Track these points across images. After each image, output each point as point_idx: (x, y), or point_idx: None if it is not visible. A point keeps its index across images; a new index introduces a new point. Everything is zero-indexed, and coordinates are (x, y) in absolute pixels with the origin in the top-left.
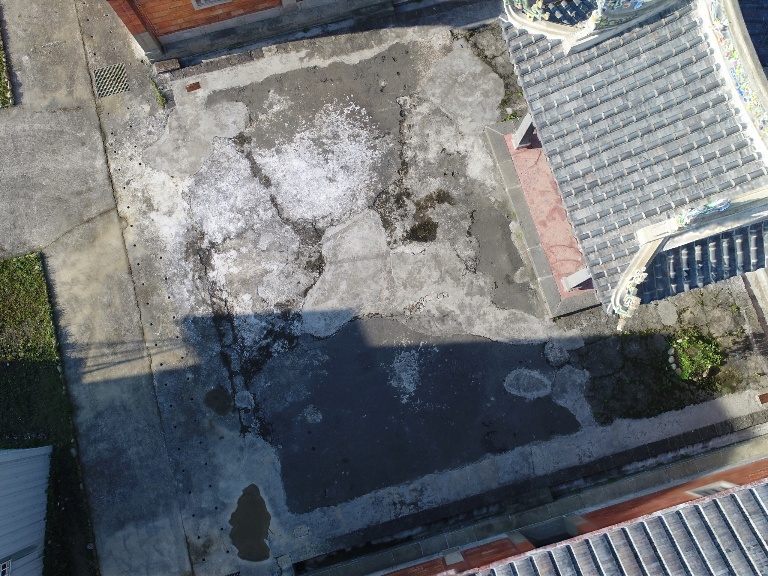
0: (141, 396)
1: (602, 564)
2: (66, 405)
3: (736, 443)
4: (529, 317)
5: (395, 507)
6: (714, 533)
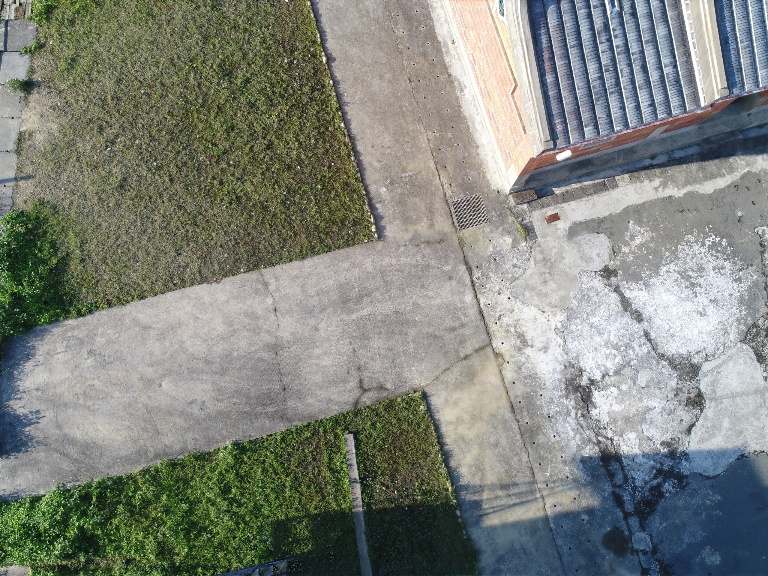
0: (539, 539)
1: None
2: (469, 550)
3: None
4: None
5: None
6: None
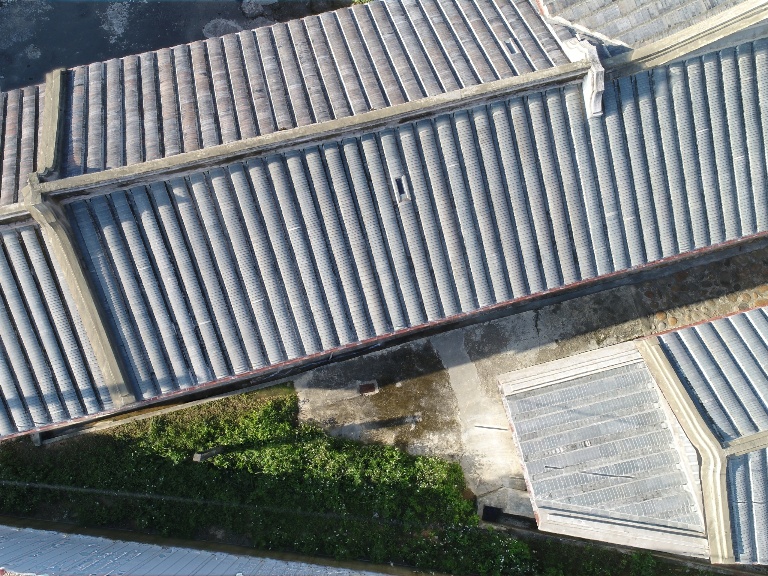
0: None
1: (176, 58)
2: None
3: None
4: None
5: None
6: (275, 39)
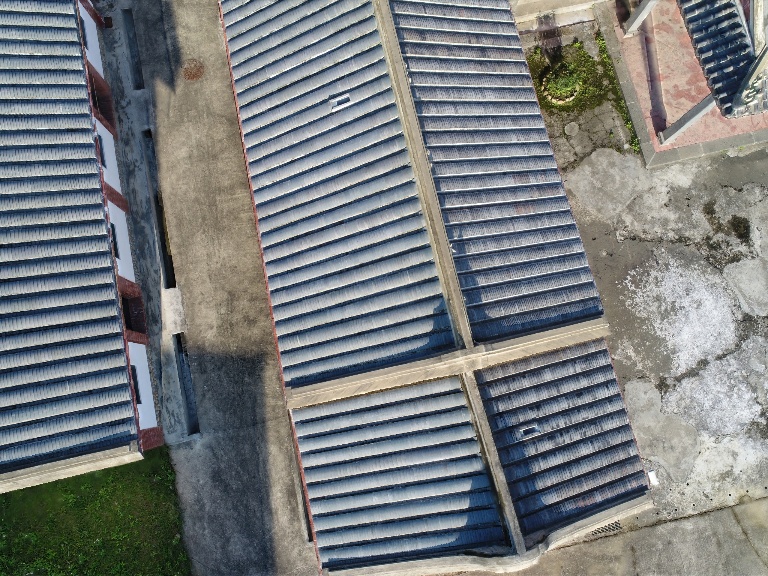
0: None
1: None
2: None
3: None
4: None
5: None
6: None
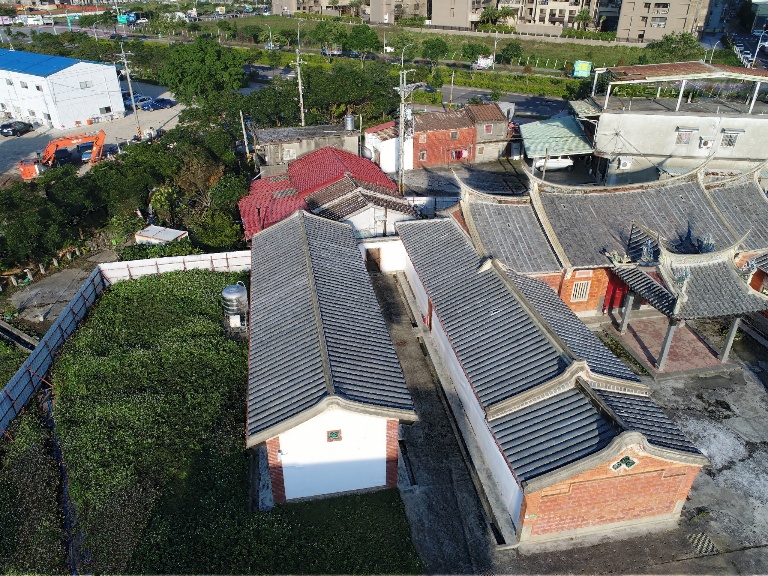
0: None
1: None
2: None
3: (759, 329)
4: (745, 375)
5: None
6: None
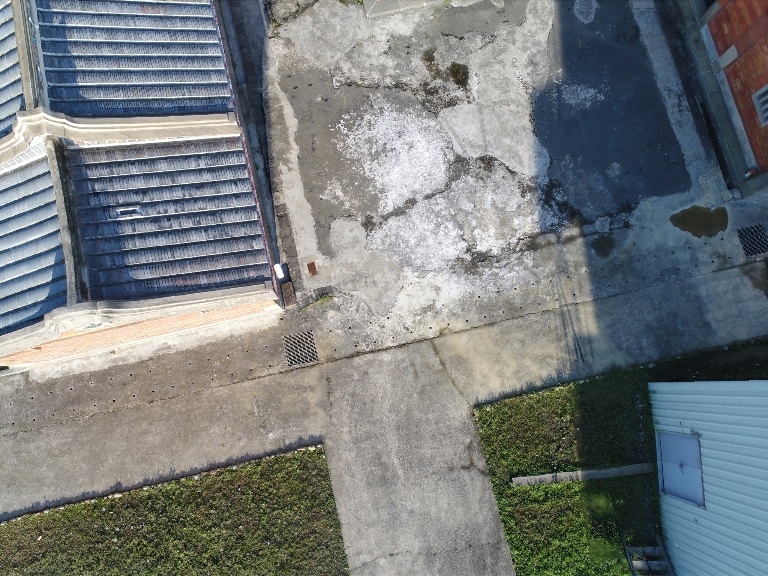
0: (602, 311)
1: None
2: (612, 374)
3: None
4: None
5: (682, 111)
6: None
